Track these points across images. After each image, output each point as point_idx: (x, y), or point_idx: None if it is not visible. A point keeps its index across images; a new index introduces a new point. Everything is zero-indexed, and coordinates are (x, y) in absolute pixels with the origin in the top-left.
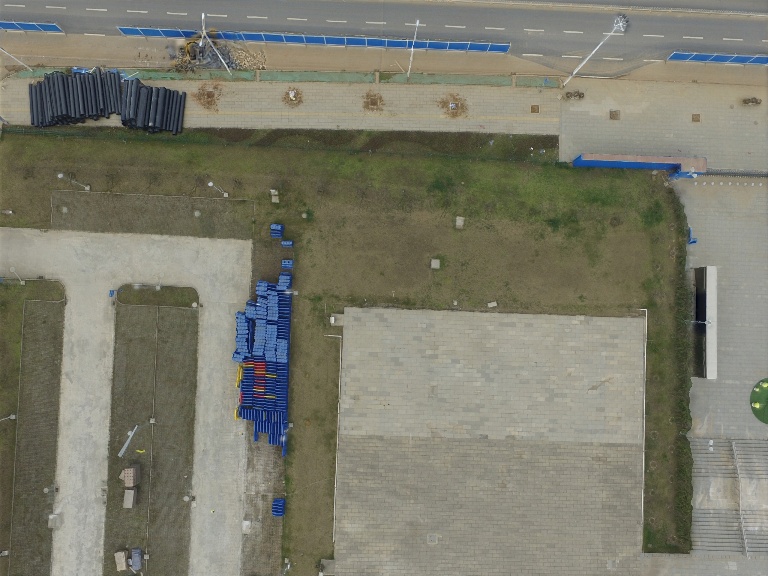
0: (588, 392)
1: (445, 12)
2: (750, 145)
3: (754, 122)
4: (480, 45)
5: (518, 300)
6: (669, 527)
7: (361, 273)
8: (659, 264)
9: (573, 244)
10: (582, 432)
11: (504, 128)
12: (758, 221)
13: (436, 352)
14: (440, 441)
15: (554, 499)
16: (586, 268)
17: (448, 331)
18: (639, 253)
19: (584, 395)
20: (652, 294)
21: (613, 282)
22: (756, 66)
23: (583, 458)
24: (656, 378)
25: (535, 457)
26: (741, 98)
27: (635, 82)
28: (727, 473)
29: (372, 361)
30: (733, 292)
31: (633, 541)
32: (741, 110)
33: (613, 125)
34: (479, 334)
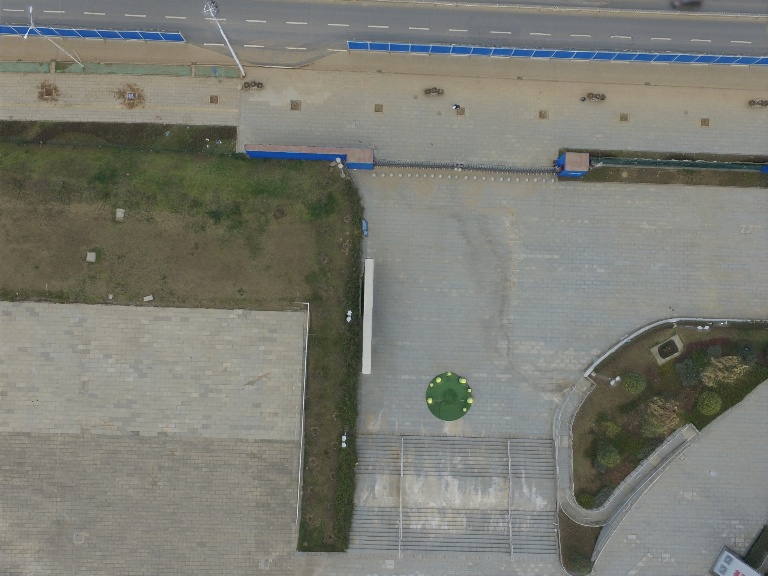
0: (244, 387)
1: (125, 1)
2: (433, 136)
3: (438, 113)
4: (151, 34)
5: (175, 294)
6: (327, 525)
7: (14, 266)
8: (326, 257)
9: (234, 237)
10: (237, 428)
11: (181, 119)
12: (438, 213)
13: (88, 347)
14: (90, 438)
15: (206, 497)
16: (247, 261)
17: (101, 325)
18: (303, 246)
19: (240, 391)
20: (317, 287)
21: (275, 275)
22: (442, 56)
23: (237, 455)
24: (319, 373)
25: (187, 454)
26: (423, 88)
27: (318, 72)
28: (394, 470)
29: (21, 356)
30: (411, 286)
31: (287, 539)
32: (425, 100)
33: (293, 116)
34: (133, 328)
